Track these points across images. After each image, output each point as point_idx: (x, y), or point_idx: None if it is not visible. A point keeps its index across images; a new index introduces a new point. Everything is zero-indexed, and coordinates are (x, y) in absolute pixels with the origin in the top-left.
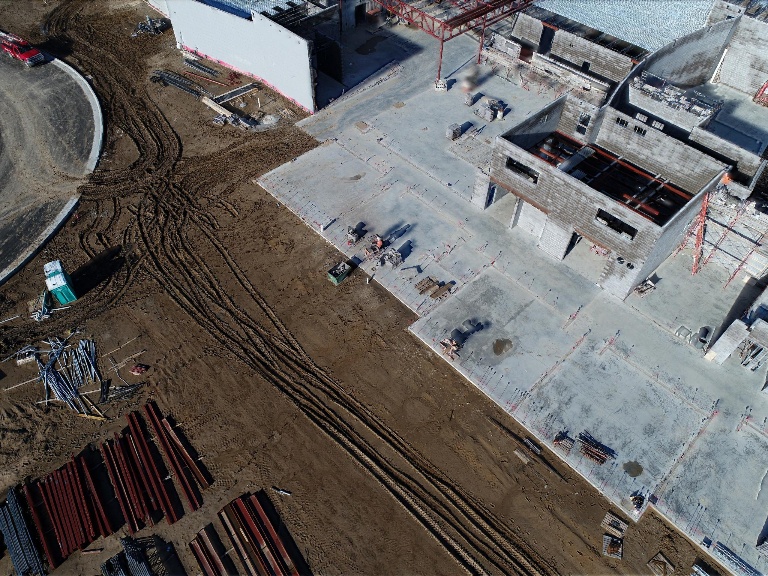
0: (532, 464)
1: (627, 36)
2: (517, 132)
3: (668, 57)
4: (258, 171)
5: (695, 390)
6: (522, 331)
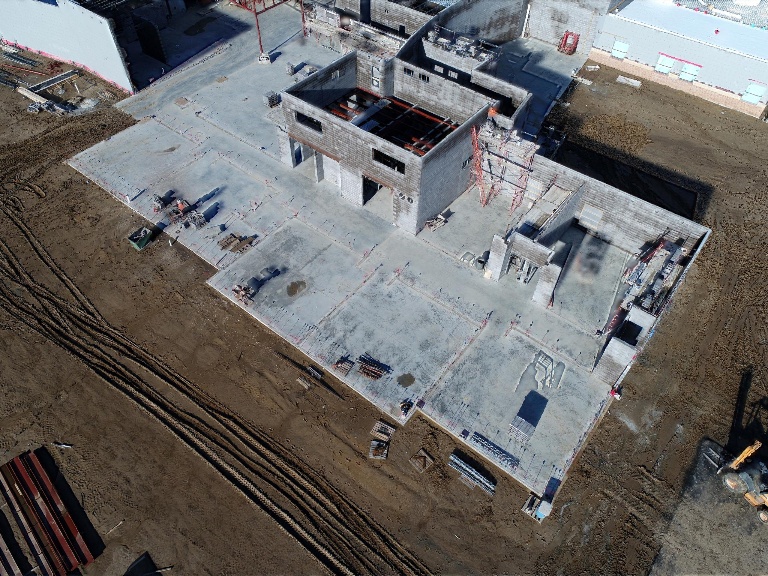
0: (313, 388)
1: None
2: (305, 88)
3: (467, 13)
4: (70, 152)
5: (472, 306)
6: (317, 272)
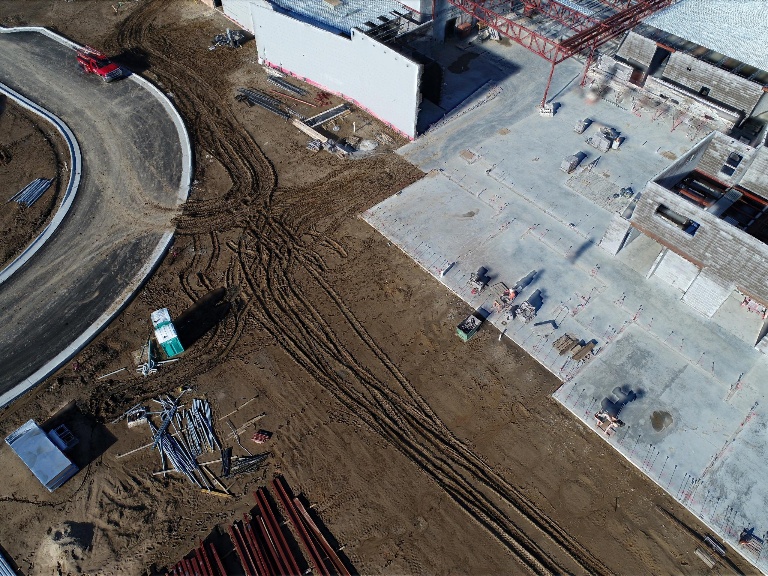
0: (718, 568)
1: (752, 60)
2: (666, 175)
3: None
4: (362, 205)
5: None
6: (681, 402)
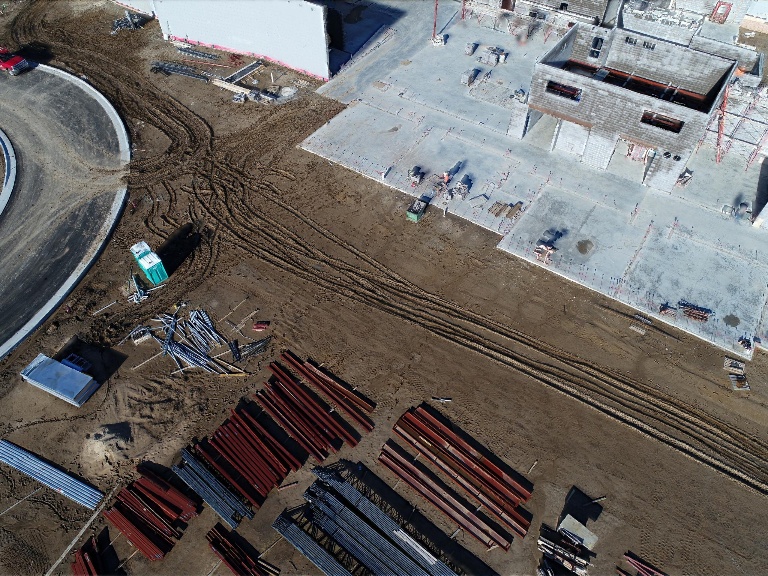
0: (648, 334)
1: None
2: (548, 59)
3: None
4: (297, 137)
5: (755, 252)
6: (596, 232)
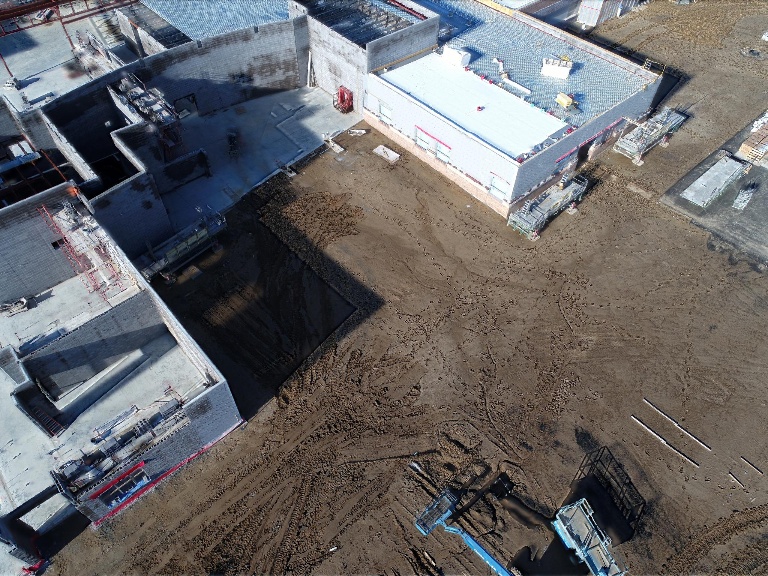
0: None
1: (201, 36)
2: None
3: (202, 58)
4: None
5: None
6: None
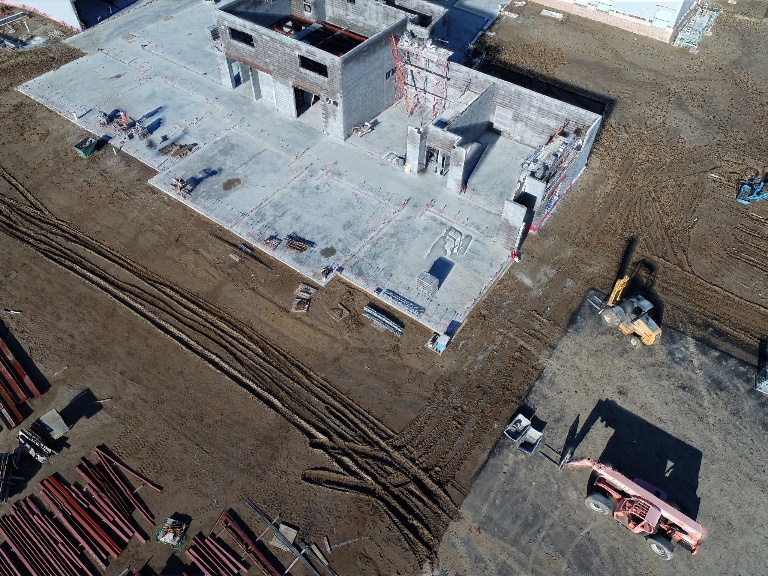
0: (243, 261)
1: None
2: (239, 8)
3: None
4: (20, 81)
5: (392, 194)
6: (251, 171)
